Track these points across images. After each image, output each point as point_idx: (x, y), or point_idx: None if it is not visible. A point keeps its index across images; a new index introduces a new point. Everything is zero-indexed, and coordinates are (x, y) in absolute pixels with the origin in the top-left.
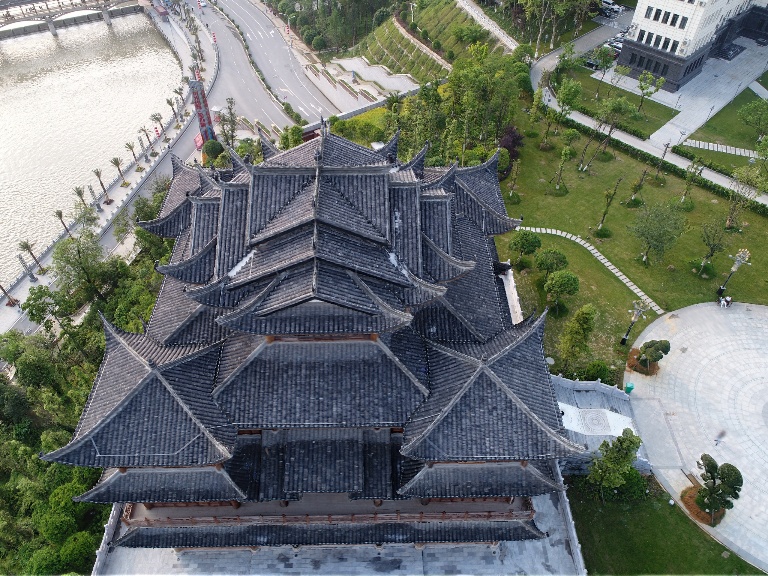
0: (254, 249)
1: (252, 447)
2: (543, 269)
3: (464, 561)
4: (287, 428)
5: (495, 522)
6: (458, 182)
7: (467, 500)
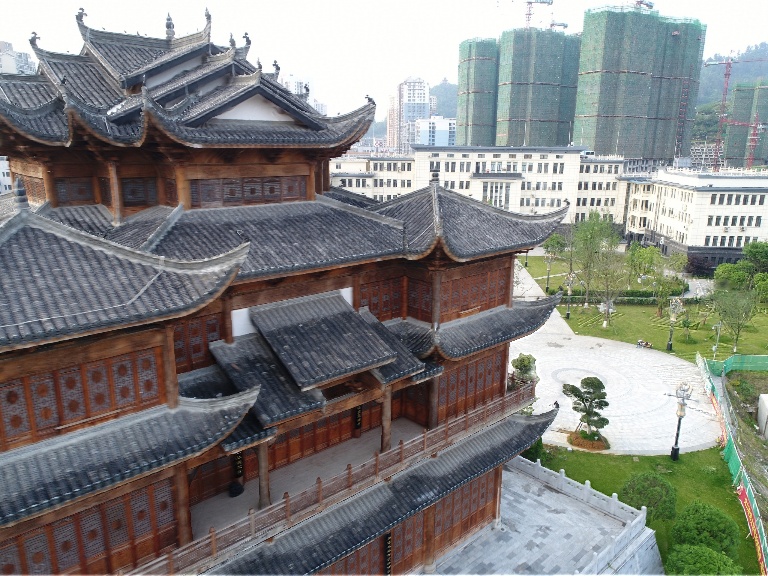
0: (126, 99)
1: (200, 387)
2: None
3: (485, 553)
4: (275, 275)
5: (502, 435)
6: None
7: (469, 410)
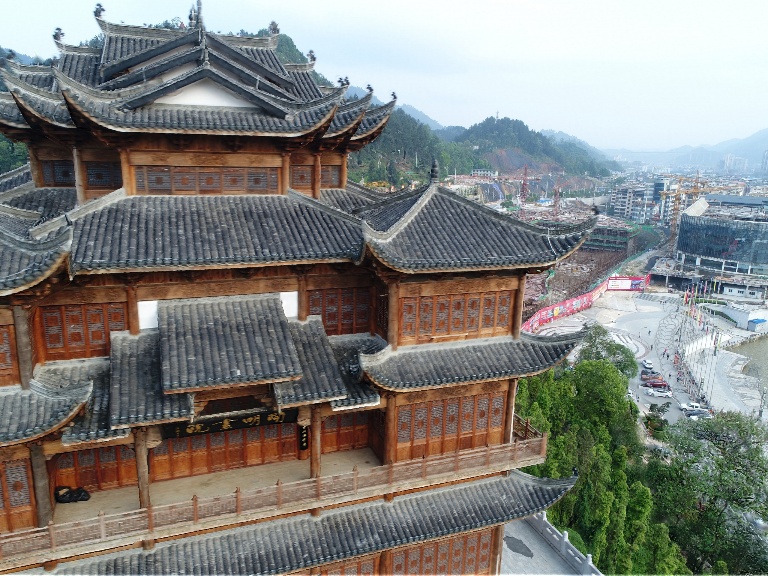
0: None
1: None
2: None
3: None
4: None
5: None
6: None
7: None
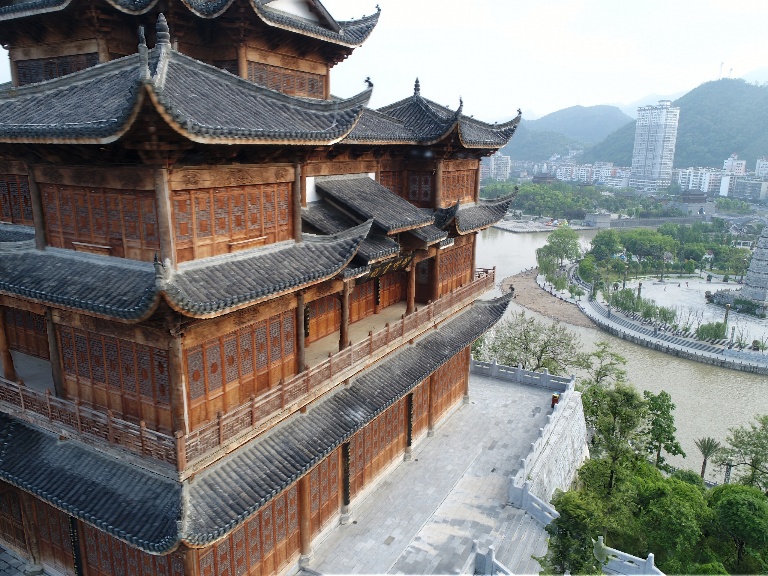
0: None
1: None
2: None
3: None
4: None
5: None
6: (136, 64)
7: None
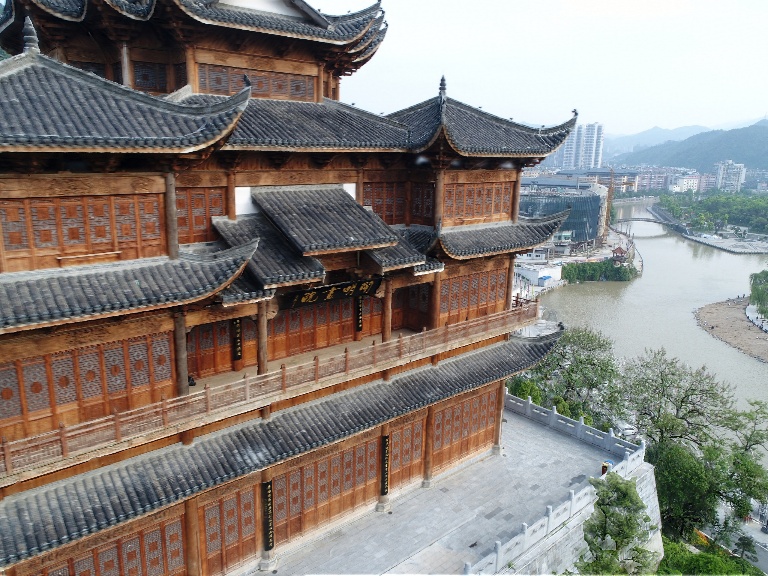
0: None
1: None
2: None
3: None
4: None
5: None
6: None
7: None
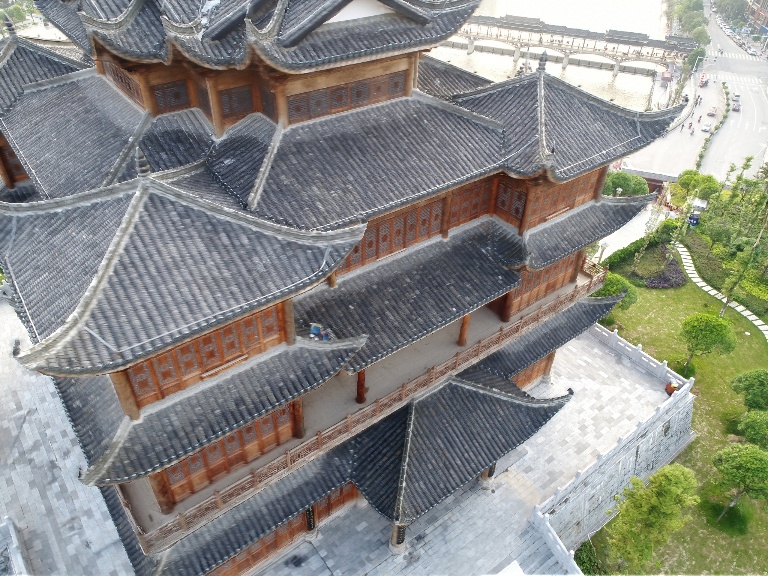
0: None
1: None
2: (754, 442)
3: None
4: None
5: None
6: (539, 89)
7: None
